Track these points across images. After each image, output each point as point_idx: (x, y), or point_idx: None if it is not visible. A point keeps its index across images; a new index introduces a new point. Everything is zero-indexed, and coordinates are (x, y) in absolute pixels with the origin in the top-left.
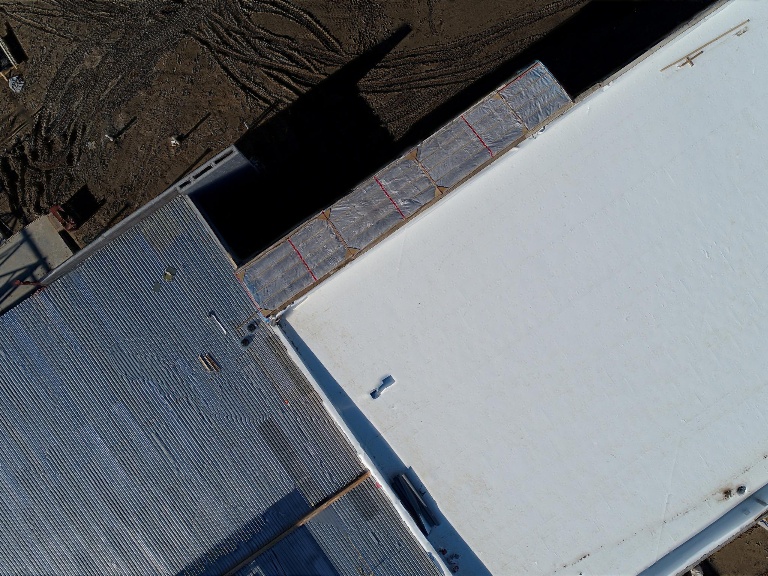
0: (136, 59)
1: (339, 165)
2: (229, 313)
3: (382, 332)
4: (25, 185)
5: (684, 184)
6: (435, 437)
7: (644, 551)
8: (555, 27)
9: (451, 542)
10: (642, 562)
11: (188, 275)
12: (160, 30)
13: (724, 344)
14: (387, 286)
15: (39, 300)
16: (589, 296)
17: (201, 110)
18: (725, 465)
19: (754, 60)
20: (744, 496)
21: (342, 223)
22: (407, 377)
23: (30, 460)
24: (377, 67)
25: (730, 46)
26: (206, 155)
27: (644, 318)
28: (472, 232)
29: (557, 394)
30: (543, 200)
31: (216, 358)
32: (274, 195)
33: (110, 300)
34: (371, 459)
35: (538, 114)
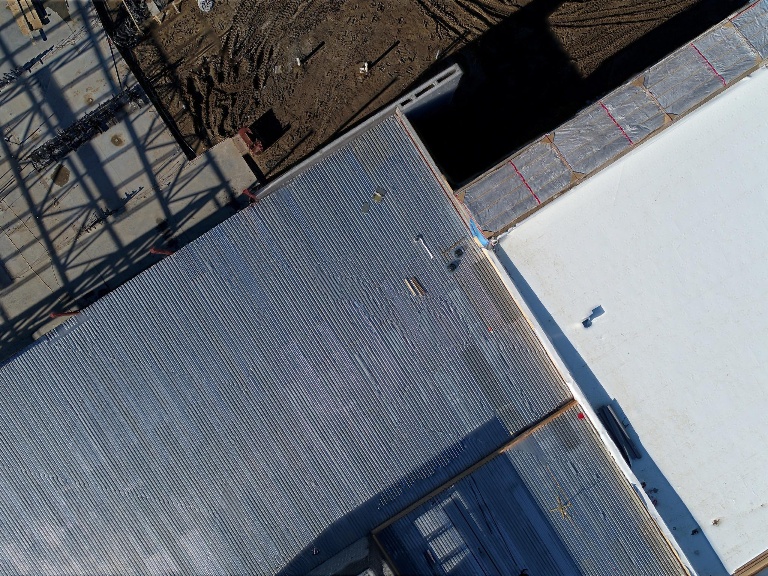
0: None
1: (527, 100)
2: (436, 237)
3: (595, 261)
4: (209, 107)
5: None
6: (641, 370)
7: None
8: None
9: (650, 476)
10: None
11: (397, 197)
12: None
13: None
14: (602, 215)
15: (248, 216)
16: None
17: (390, 38)
18: None
19: None
20: None
21: (567, 147)
22: (617, 308)
23: (233, 375)
24: (570, 1)
25: None
26: (393, 84)
27: None
28: (691, 164)
29: (766, 332)
30: (765, 134)
31: (421, 282)
32: (459, 127)
33: (318, 219)
34: (580, 388)
35: None
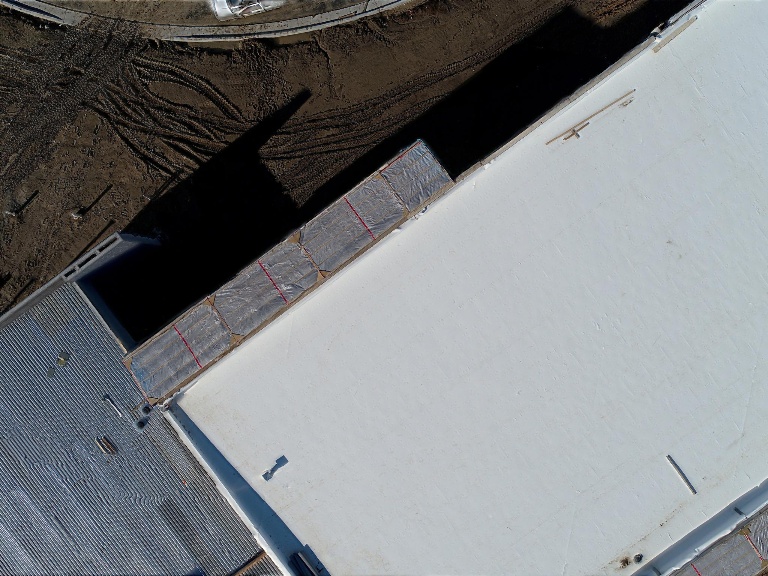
0: (35, 133)
1: (243, 233)
2: (123, 396)
3: (273, 413)
4: None
5: (573, 257)
6: (330, 515)
7: None
8: (456, 88)
9: None
10: None
11: (81, 360)
12: (58, 102)
13: (617, 415)
14: (277, 368)
15: None
16: (480, 371)
17: (102, 182)
18: (621, 534)
19: (641, 130)
20: (641, 564)
21: (226, 309)
22: (300, 457)
23: None
24: (278, 134)
25: (617, 116)
26: (109, 227)
27: (536, 392)
28: (360, 311)
29: (451, 469)
30: (431, 277)
31: (112, 441)
32: (179, 265)
33: (4, 387)
34: (265, 540)
35: (419, 195)
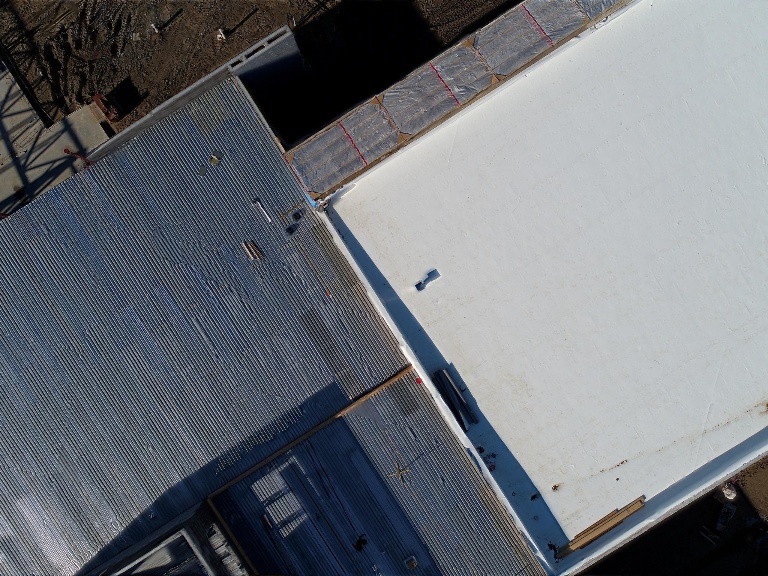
0: None
1: (386, 67)
2: (274, 201)
3: (429, 225)
4: (68, 74)
5: (745, 87)
6: (478, 334)
7: (683, 459)
8: None
9: (489, 441)
10: (680, 470)
11: (234, 160)
12: None
13: None
14: (437, 178)
15: (83, 178)
16: (641, 198)
17: (248, 5)
18: None
19: None
20: None
21: (395, 108)
22: (452, 272)
23: (69, 339)
24: None
25: None
26: None
27: (696, 223)
28: (526, 126)
29: (603, 296)
30: (600, 97)
31: (259, 246)
32: (319, 95)
33: (155, 182)
34: (413, 351)
35: (601, 3)
